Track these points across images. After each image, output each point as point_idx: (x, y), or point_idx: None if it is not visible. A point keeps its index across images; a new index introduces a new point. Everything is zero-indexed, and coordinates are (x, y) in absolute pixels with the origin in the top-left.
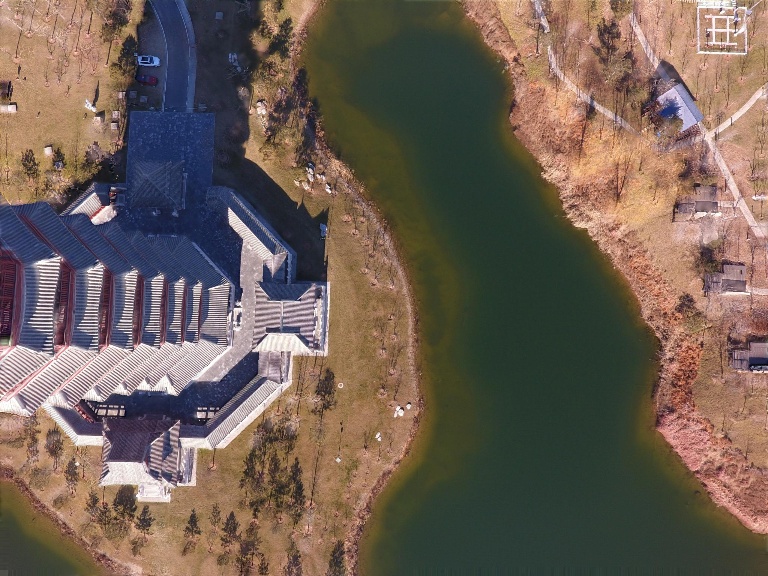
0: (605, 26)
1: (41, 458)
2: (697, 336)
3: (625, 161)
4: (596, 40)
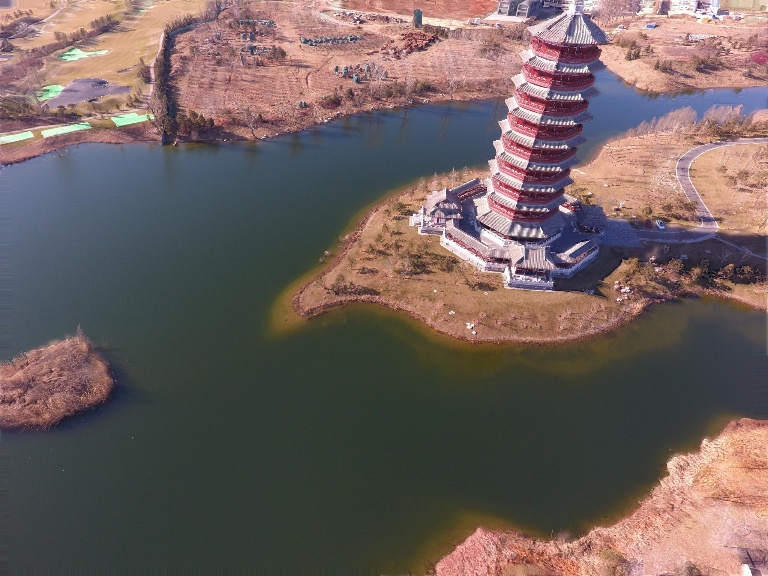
0: None
1: (429, 193)
2: (596, 575)
3: (762, 501)
4: None
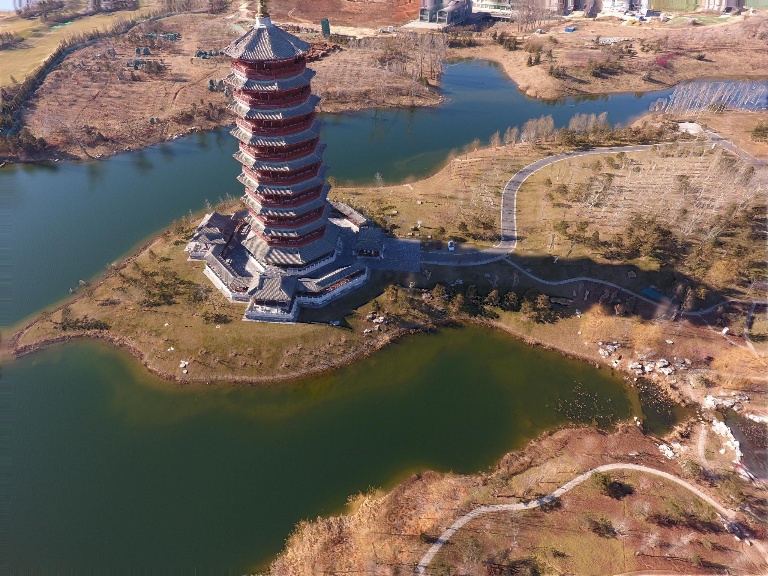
0: (536, 565)
1: None
2: None
3: None
4: (517, 554)
